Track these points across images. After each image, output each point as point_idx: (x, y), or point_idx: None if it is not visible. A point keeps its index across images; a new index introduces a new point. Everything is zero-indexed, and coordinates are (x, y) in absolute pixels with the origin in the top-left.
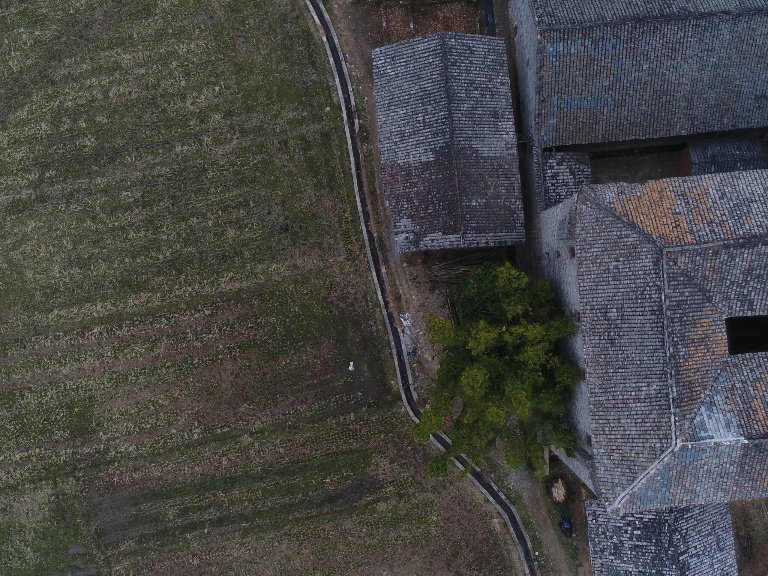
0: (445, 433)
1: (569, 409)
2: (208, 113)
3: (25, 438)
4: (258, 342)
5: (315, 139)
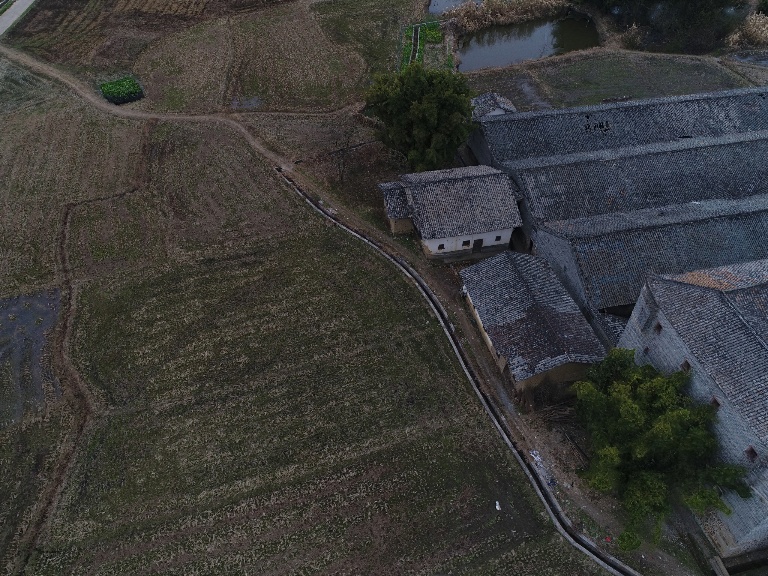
0: (612, 555)
1: (719, 462)
2: (337, 333)
3: None
4: (404, 495)
5: (422, 340)
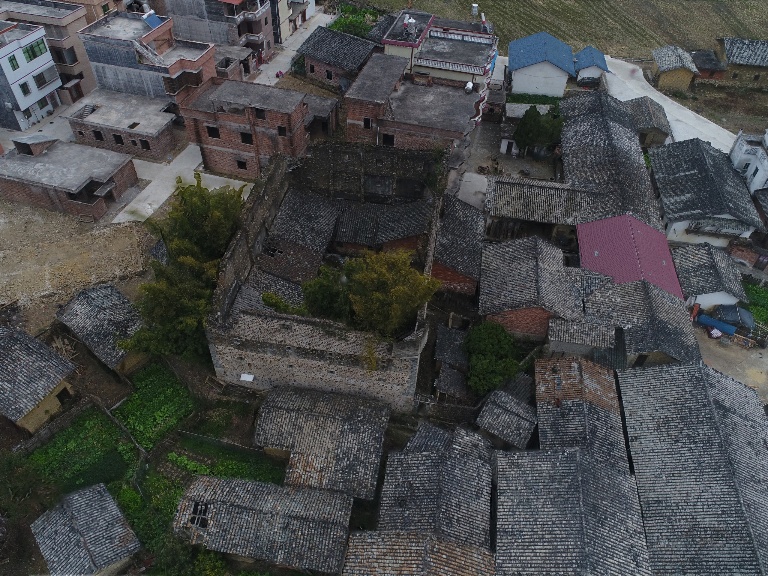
0: None
1: None
2: None
3: (741, 0)
4: None
5: None
